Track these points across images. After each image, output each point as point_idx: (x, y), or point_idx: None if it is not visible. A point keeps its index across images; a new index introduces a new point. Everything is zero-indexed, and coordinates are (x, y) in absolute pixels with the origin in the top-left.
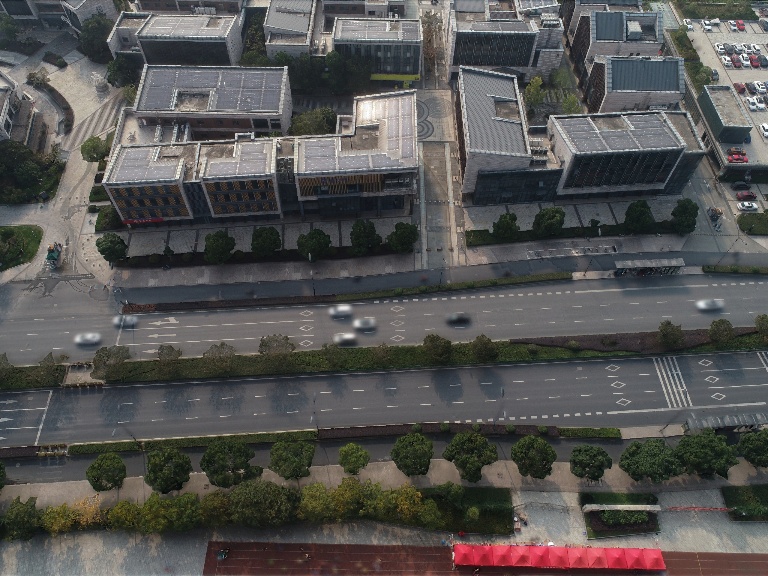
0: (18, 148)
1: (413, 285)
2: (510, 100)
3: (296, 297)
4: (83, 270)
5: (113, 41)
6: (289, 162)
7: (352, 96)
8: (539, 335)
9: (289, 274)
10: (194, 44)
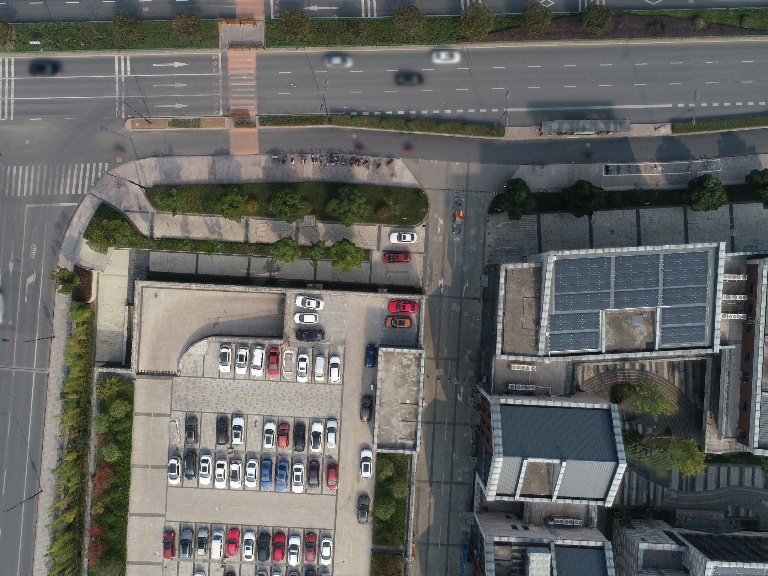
0: None
1: None
2: None
3: None
4: None
5: None
6: None
7: None
8: (729, 45)
9: None
10: None
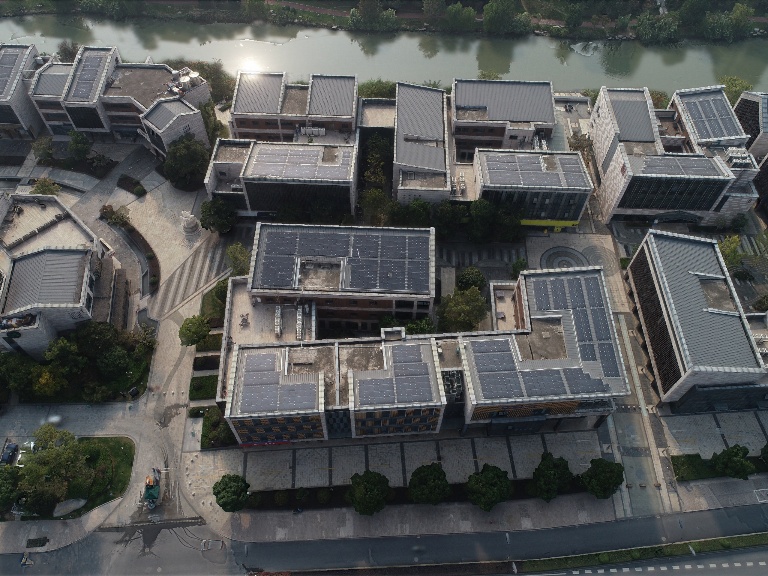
0: (102, 333)
1: (619, 544)
2: (717, 278)
3: (472, 565)
4: (190, 511)
5: (210, 180)
6: (457, 377)
7: (493, 243)
8: None
9: (456, 523)
10: (310, 187)
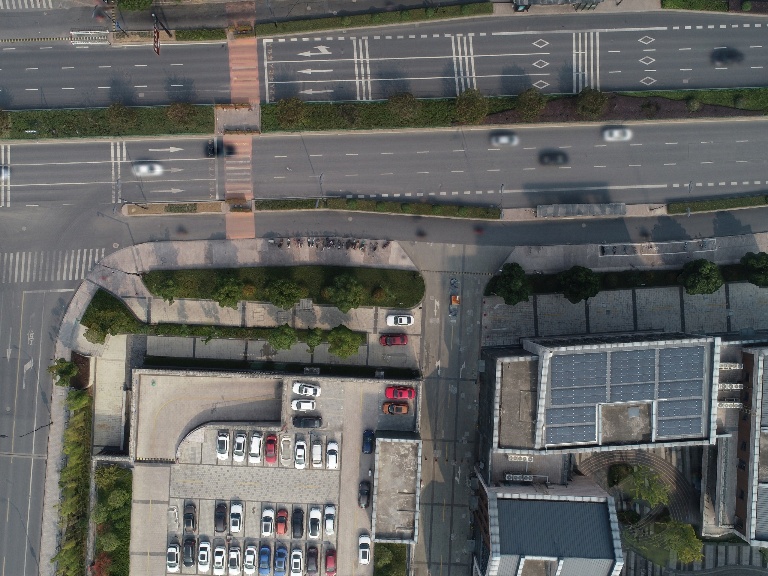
0: None
1: None
2: None
3: None
4: None
5: None
6: None
7: None
8: (723, 125)
9: None
10: None
